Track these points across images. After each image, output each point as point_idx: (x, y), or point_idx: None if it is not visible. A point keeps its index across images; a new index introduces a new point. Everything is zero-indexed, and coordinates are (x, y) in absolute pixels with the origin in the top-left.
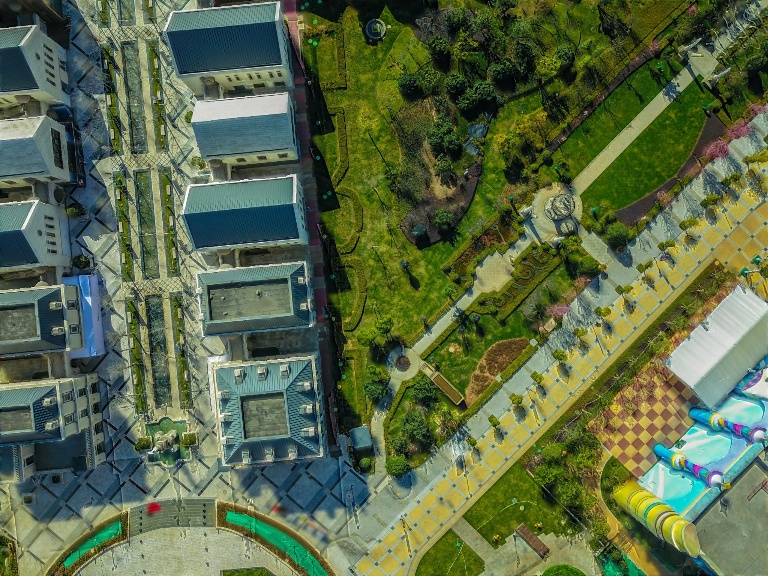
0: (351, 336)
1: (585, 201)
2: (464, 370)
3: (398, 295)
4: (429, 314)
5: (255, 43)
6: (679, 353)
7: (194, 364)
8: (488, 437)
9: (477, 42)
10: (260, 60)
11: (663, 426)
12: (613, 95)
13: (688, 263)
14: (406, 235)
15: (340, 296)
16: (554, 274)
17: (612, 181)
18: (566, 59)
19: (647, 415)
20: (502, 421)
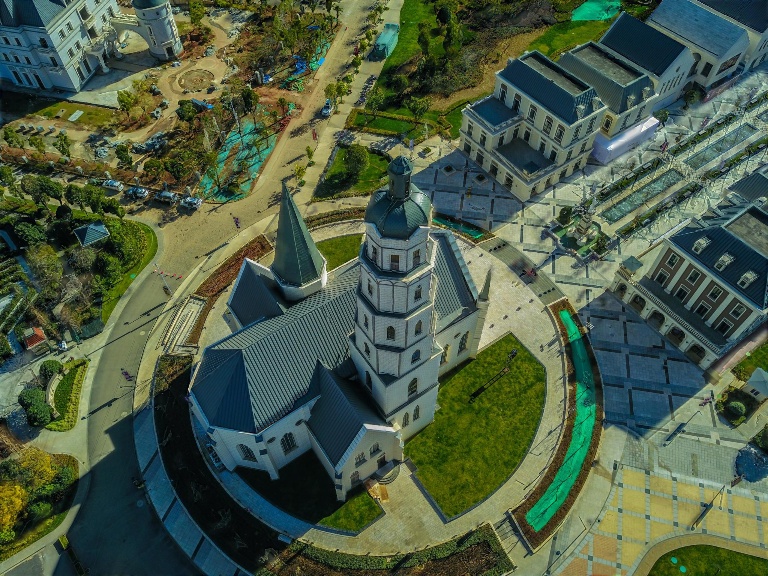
0: None
1: None
2: None
3: None
4: None
5: None
6: None
7: (660, 223)
8: None
9: None
10: None
11: None
12: None
13: None
14: None
15: None
16: None
17: None
18: None
19: None
20: None
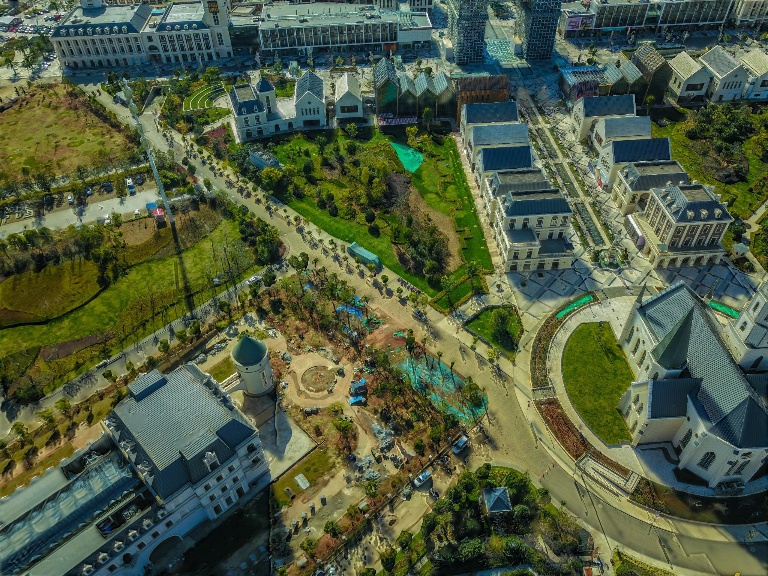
0: None
1: None
2: None
3: None
4: (750, 207)
5: (622, 104)
6: None
7: (613, 228)
8: None
9: None
10: (624, 112)
11: None
12: None
13: None
14: (718, 180)
15: None
16: None
17: None
18: None
19: None
20: None
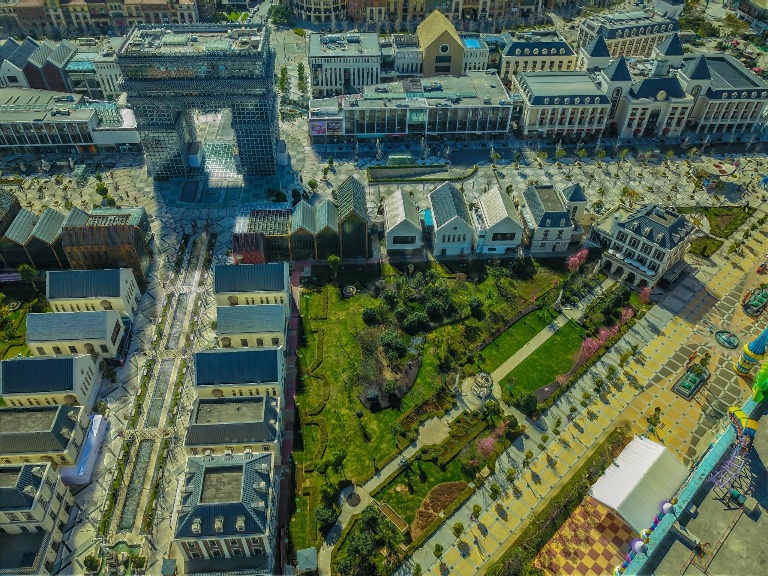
0: (310, 476)
1: (503, 386)
2: (410, 507)
3: (353, 445)
4: (379, 460)
5: (269, 276)
6: (599, 484)
7: (165, 495)
8: (434, 571)
9: (414, 289)
10: (270, 287)
11: (607, 565)
12: (513, 327)
13: (594, 430)
14: (363, 403)
15: (304, 446)
16: (484, 434)
17: (522, 374)
18: (476, 302)
19: (588, 554)
20: (447, 555)
